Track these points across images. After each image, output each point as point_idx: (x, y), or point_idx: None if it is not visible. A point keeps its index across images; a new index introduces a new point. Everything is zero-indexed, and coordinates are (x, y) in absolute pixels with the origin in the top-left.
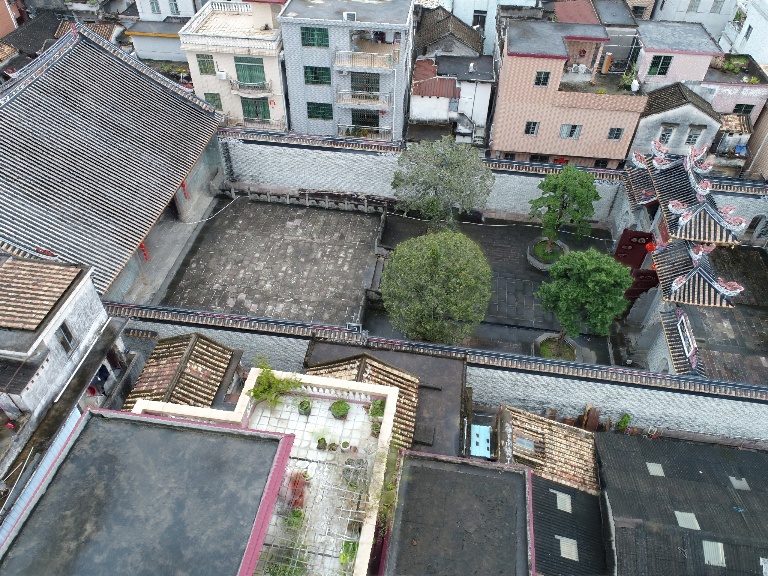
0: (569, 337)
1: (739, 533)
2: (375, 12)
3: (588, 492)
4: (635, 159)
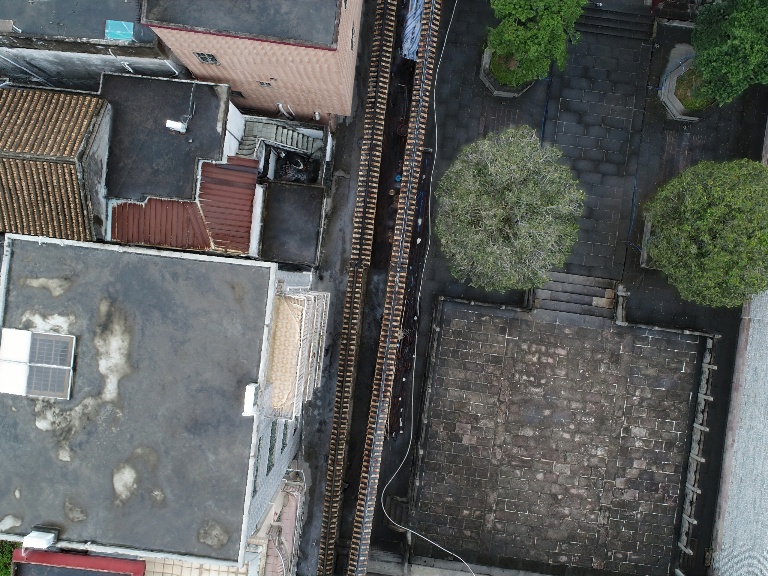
0: None
1: None
2: (188, 340)
3: None
4: None
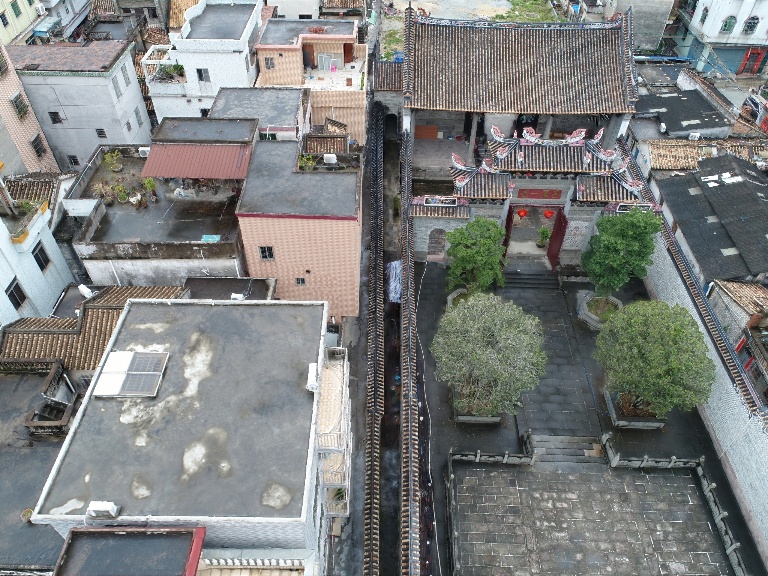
0: (583, 299)
1: (766, 219)
2: (260, 351)
3: (764, 287)
4: (459, 183)
